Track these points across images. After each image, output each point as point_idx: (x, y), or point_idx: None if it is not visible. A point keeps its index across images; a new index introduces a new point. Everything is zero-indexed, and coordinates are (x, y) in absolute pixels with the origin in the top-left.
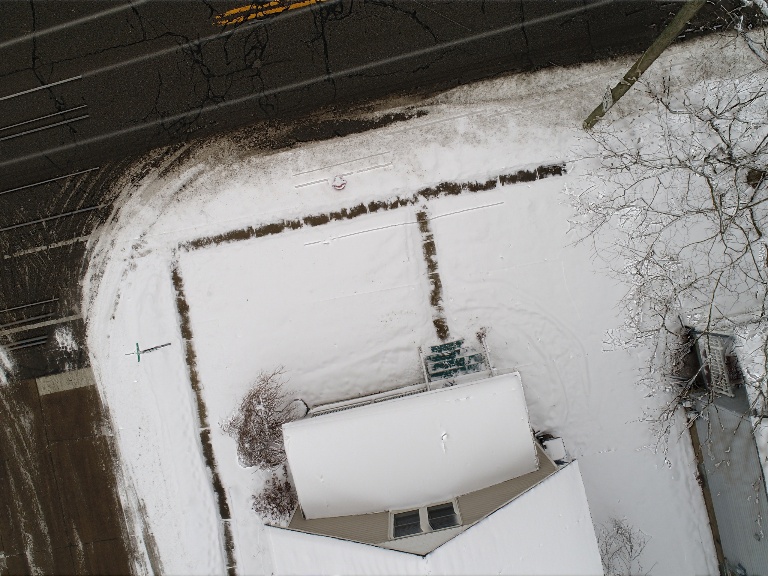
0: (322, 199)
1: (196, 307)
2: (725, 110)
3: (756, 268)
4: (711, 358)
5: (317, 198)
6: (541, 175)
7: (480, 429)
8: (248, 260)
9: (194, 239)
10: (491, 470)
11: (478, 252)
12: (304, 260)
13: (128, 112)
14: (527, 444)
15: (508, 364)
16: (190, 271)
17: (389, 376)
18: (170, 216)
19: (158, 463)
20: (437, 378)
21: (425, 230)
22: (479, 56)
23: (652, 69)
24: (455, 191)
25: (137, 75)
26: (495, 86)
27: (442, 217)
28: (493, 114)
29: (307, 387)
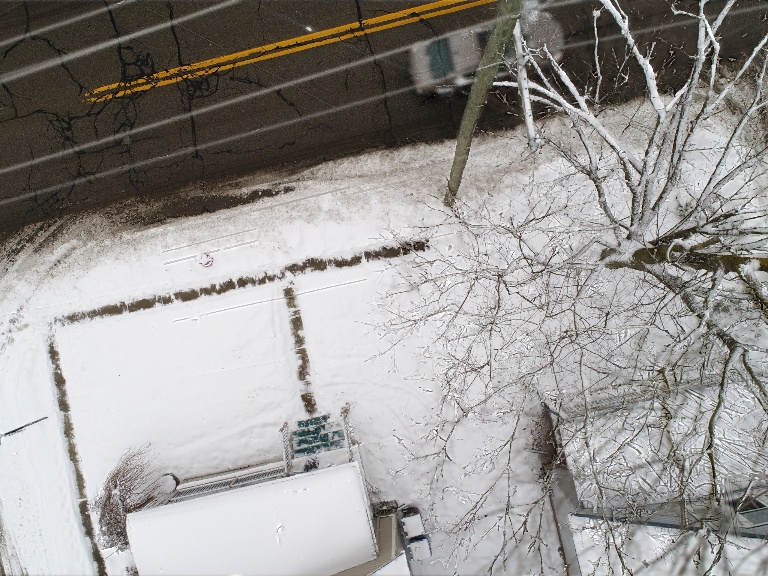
0: (191, 275)
1: (71, 381)
2: (525, 223)
3: (555, 379)
4: (509, 469)
5: (186, 274)
6: (405, 251)
7: (315, 521)
8: (119, 336)
9: (69, 313)
10: (324, 562)
11: (342, 328)
12: (173, 336)
13: (2, 188)
14: (362, 535)
15: (373, 438)
16: (65, 346)
17: (257, 451)
18: (45, 291)
19: (38, 533)
20: (300, 455)
21: (292, 306)
22: (343, 133)
23: (512, 146)
24: (321, 267)
25: (10, 152)
26: (359, 162)
27: (307, 293)
28: (356, 191)
29: (177, 462)
